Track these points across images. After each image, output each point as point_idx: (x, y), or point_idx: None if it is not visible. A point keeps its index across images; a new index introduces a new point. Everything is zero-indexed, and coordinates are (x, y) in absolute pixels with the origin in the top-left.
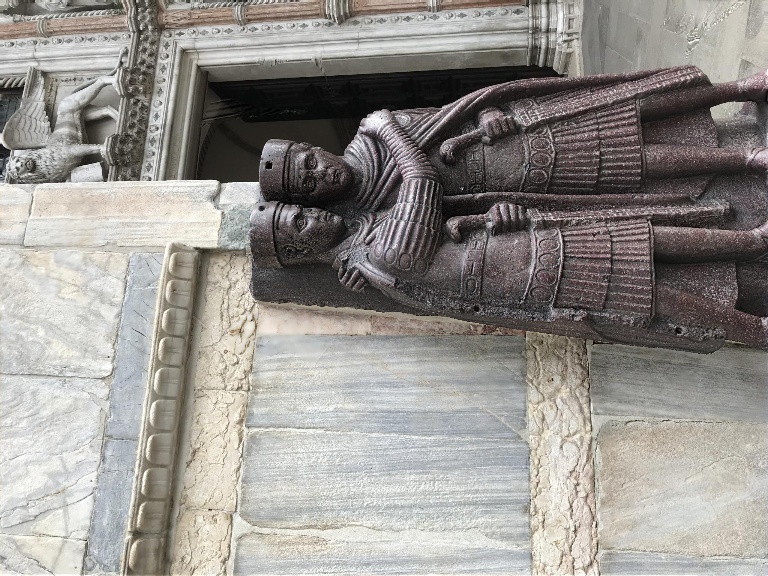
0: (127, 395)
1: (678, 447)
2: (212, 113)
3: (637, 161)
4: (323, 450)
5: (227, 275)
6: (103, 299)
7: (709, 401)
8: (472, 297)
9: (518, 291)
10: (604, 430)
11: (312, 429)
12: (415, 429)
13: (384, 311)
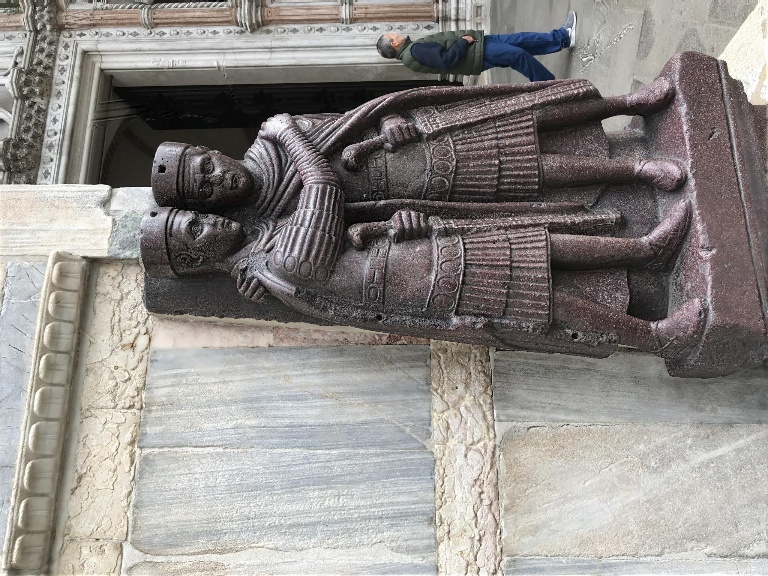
0: (3, 418)
1: (577, 451)
2: (102, 114)
3: (534, 170)
4: (222, 469)
5: (118, 286)
6: None
7: (605, 404)
8: (374, 305)
9: (420, 299)
10: (507, 437)
11: (210, 447)
12: (319, 443)
13: (286, 321)
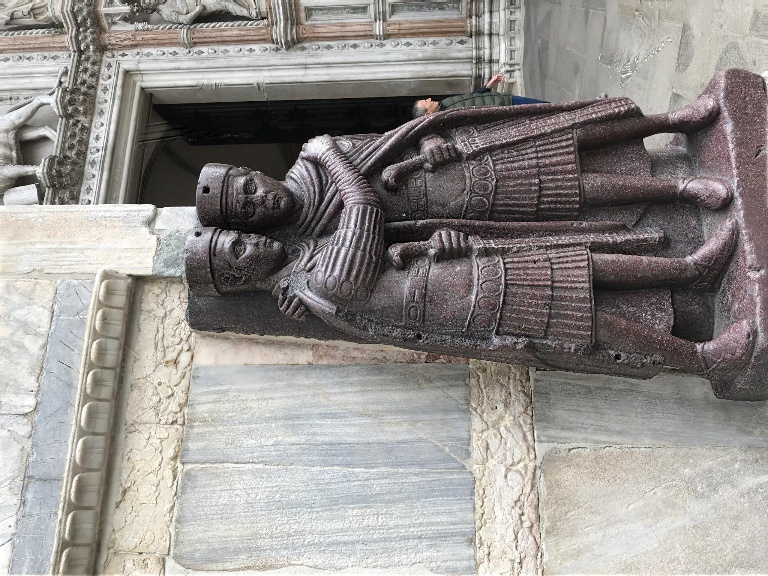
0: (52, 432)
1: (620, 473)
2: (148, 136)
3: (575, 189)
4: (262, 486)
5: (162, 303)
6: (27, 329)
7: (649, 426)
8: (414, 325)
9: (460, 319)
10: (548, 458)
11: (251, 464)
12: (358, 461)
13: (326, 340)
